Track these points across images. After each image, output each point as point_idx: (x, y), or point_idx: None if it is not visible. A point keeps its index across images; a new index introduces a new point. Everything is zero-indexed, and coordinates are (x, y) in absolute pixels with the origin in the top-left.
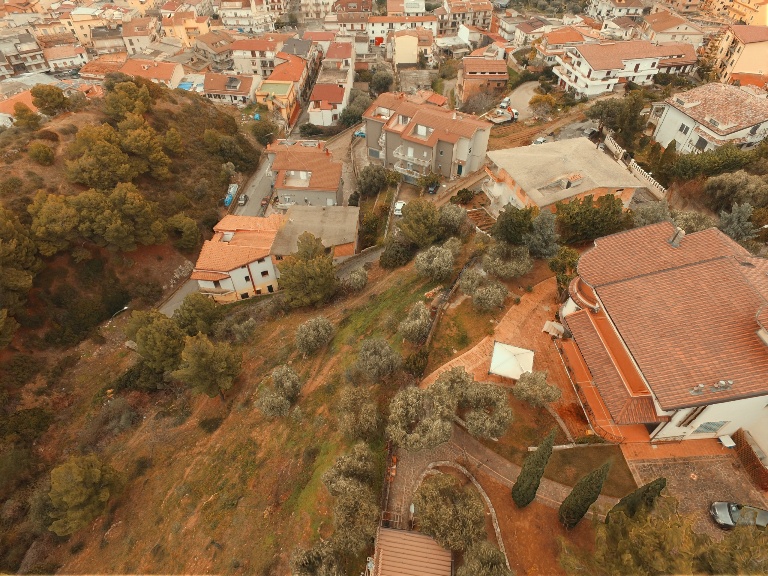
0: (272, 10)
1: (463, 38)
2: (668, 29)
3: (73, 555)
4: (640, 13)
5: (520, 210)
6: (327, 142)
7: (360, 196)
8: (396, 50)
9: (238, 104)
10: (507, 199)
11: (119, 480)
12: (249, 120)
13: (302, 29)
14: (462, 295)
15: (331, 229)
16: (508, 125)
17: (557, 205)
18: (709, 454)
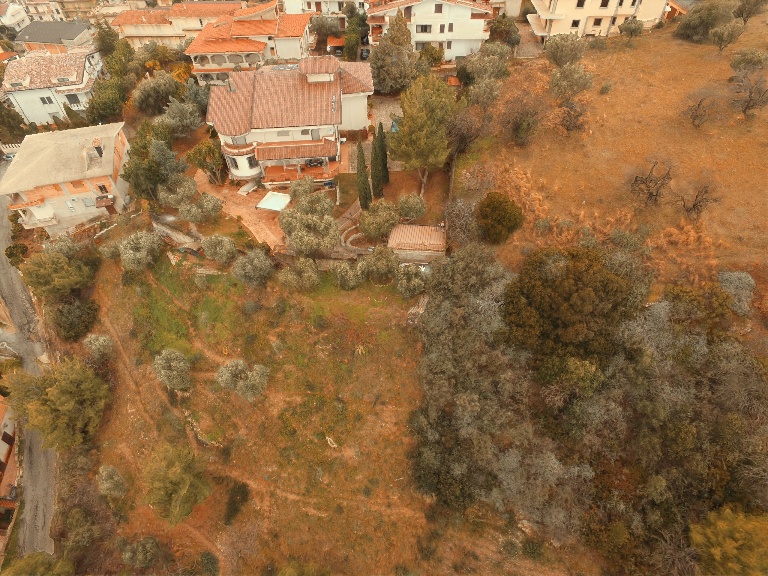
0: None
1: None
2: None
3: None
4: None
5: None
6: None
7: None
8: None
9: None
10: (65, 208)
11: (294, 568)
12: None
13: None
14: (192, 233)
15: None
16: None
17: (135, 149)
18: (348, 148)
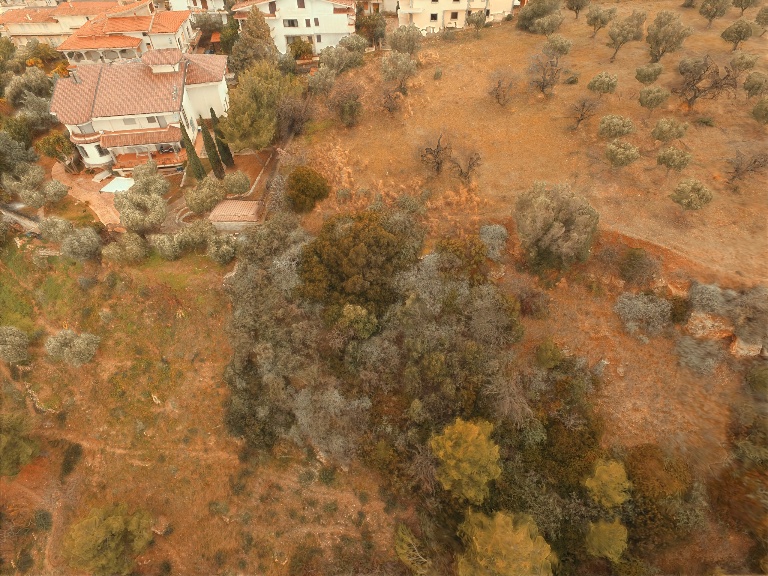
0: None
1: None
2: None
3: (171, 569)
4: None
5: None
6: None
7: None
8: None
9: None
10: None
11: None
12: None
13: None
14: (38, 218)
15: None
16: None
17: None
18: None
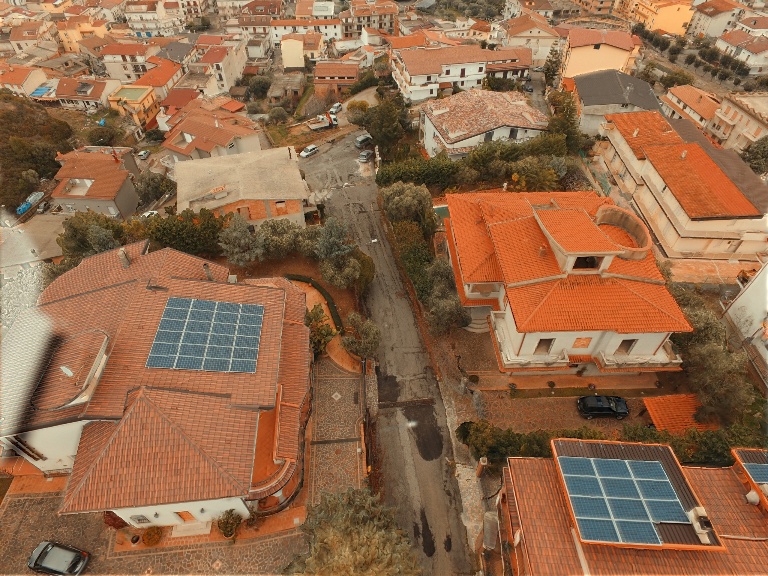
0: (189, 13)
1: (364, 41)
2: (521, 33)
3: None
4: (550, 16)
5: (111, 225)
6: (161, 148)
7: (144, 204)
8: (282, 54)
9: (89, 109)
10: None
11: None
12: (92, 126)
13: (200, 33)
14: None
15: None
16: (322, 131)
17: None
18: None
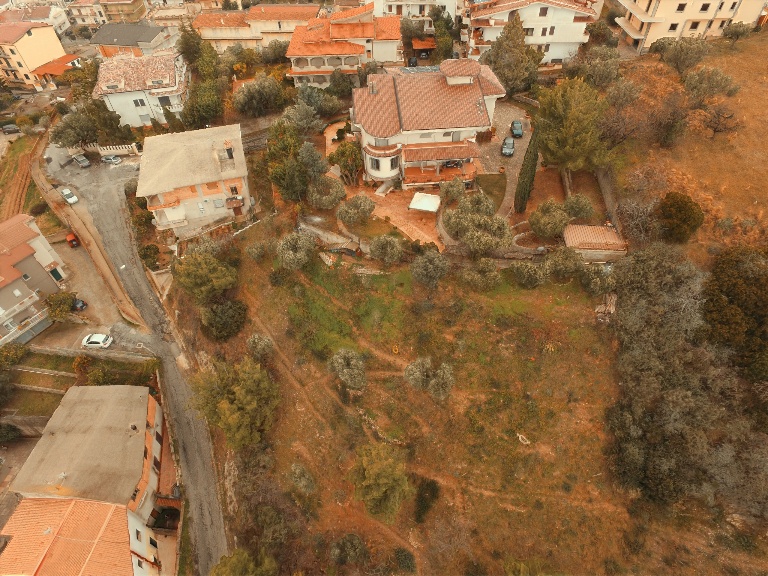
0: None
1: None
2: None
3: None
4: None
5: None
6: None
7: None
8: None
9: None
10: (196, 209)
11: None
12: None
13: None
14: (343, 233)
15: (111, 416)
16: None
17: (277, 151)
18: None
